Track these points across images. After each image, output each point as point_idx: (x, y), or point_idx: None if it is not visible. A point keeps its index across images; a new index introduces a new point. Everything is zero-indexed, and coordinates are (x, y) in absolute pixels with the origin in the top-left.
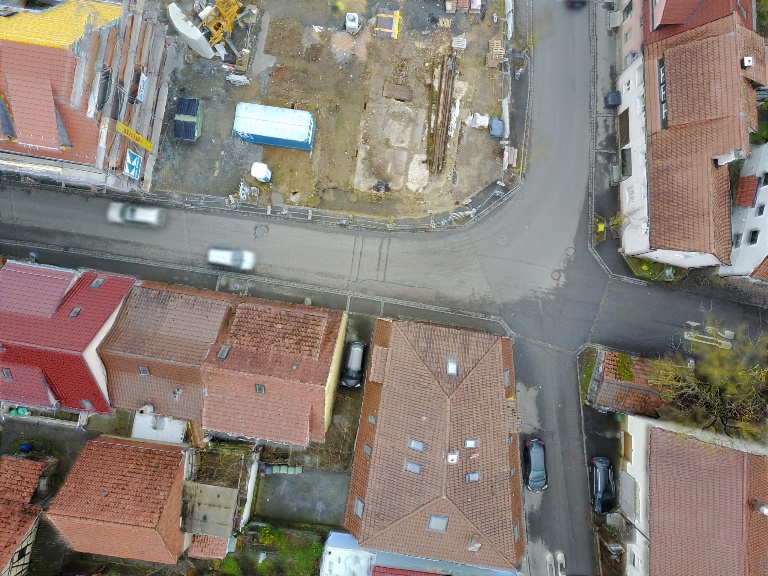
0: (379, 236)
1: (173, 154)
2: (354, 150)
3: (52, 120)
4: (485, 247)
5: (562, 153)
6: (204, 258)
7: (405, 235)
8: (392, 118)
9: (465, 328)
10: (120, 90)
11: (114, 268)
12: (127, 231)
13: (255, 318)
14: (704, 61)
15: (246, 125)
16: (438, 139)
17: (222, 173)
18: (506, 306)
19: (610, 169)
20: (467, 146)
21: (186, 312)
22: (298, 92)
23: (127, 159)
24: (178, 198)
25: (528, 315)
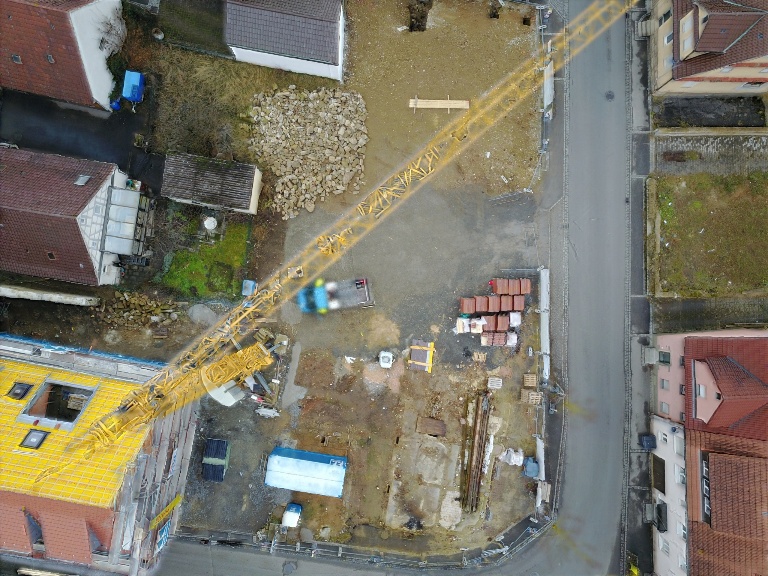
0: (410, 573)
1: (199, 488)
2: (386, 485)
3: (84, 545)
4: None
5: (595, 488)
6: None
7: (436, 572)
8: (425, 454)
9: None
10: (154, 492)
11: None
12: None
13: None
14: (751, 479)
15: (278, 479)
16: (472, 480)
17: (250, 507)
18: None
19: (643, 506)
20: (500, 481)
21: None
22: (329, 425)
23: (157, 540)
24: (204, 534)
25: None
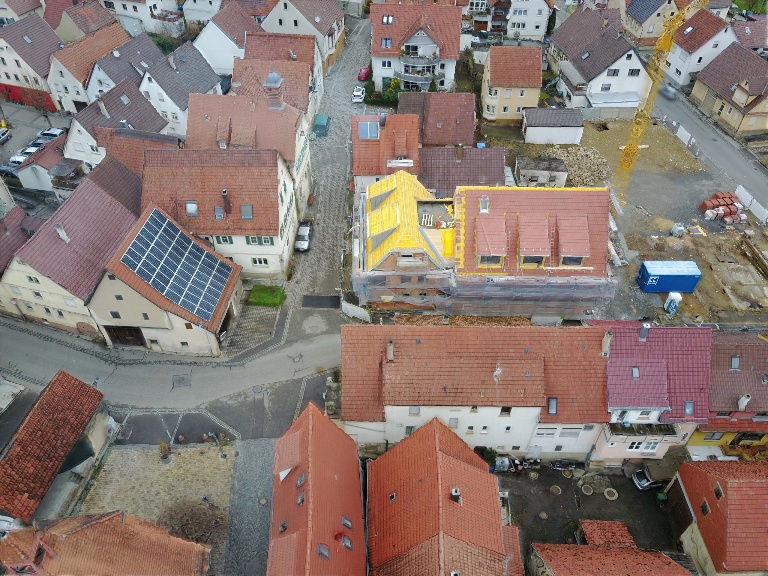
0: None
1: None
2: (721, 290)
3: (586, 238)
4: None
5: None
6: None
7: None
8: (734, 271)
9: None
10: None
11: None
12: None
13: None
14: None
15: (656, 271)
16: None
17: (639, 311)
18: None
19: None
20: None
21: None
22: None
23: None
24: None
25: None
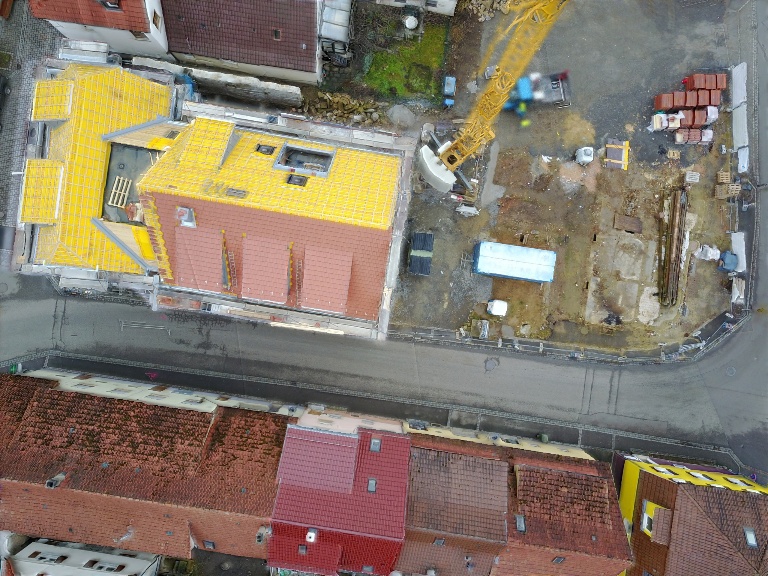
0: (610, 368)
1: (402, 286)
2: (584, 282)
3: (344, 288)
4: (714, 379)
5: None
6: (434, 392)
7: (635, 367)
8: (623, 250)
9: (695, 460)
10: None
11: (343, 403)
12: (356, 365)
13: (539, 481)
14: None
15: (491, 265)
16: (672, 273)
17: (451, 305)
18: (735, 438)
19: None
20: (696, 278)
21: (469, 476)
22: (528, 223)
23: None
24: (407, 331)
25: (757, 447)
